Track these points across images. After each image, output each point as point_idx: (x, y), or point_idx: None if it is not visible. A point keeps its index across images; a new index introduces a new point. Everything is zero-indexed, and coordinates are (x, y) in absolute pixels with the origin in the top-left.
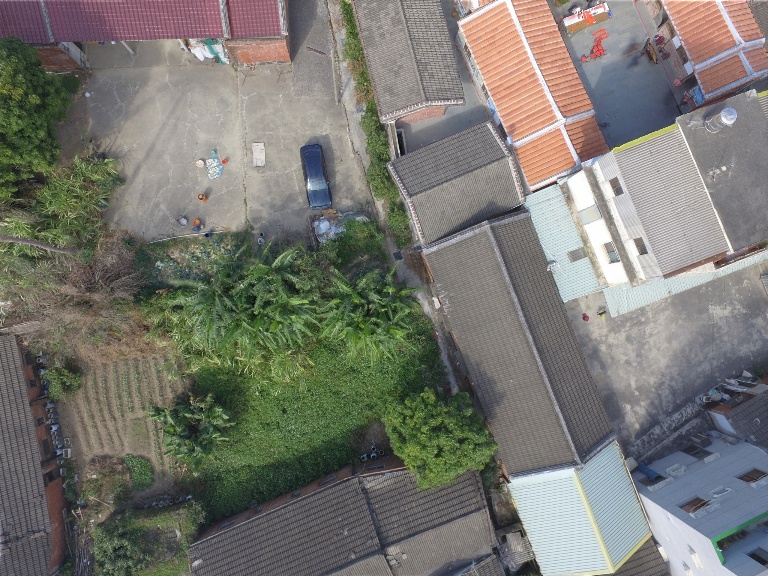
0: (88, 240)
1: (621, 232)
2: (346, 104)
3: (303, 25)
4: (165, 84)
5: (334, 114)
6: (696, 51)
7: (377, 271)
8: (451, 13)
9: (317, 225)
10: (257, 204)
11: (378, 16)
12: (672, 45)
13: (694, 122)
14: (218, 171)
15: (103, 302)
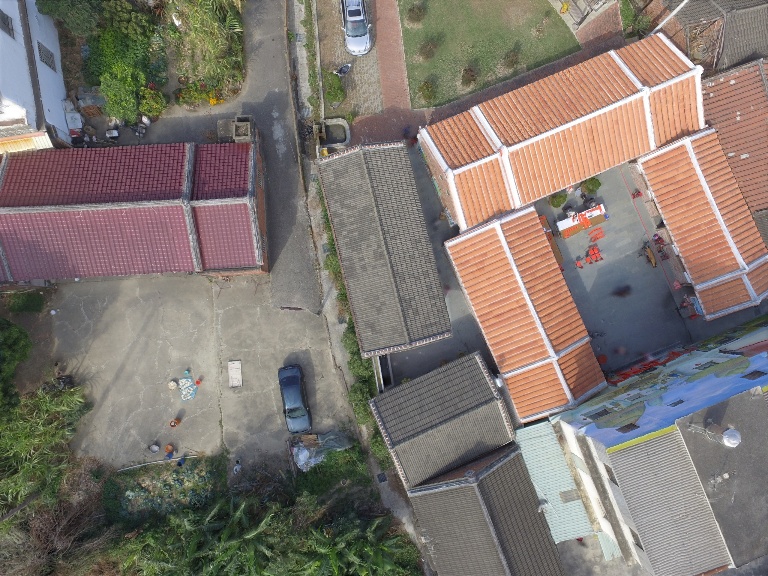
0: (53, 478)
1: (616, 510)
2: (327, 315)
3: (282, 232)
4: (135, 298)
5: (315, 327)
6: (697, 270)
7: (358, 523)
8: (438, 217)
9: (296, 453)
10: (233, 426)
11: (359, 247)
12: (672, 251)
13: (694, 426)
14: (192, 391)
15: (65, 575)
